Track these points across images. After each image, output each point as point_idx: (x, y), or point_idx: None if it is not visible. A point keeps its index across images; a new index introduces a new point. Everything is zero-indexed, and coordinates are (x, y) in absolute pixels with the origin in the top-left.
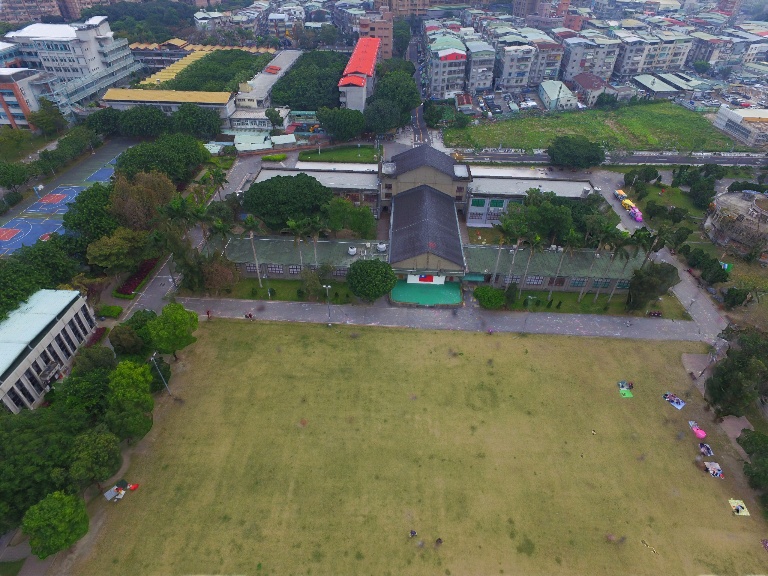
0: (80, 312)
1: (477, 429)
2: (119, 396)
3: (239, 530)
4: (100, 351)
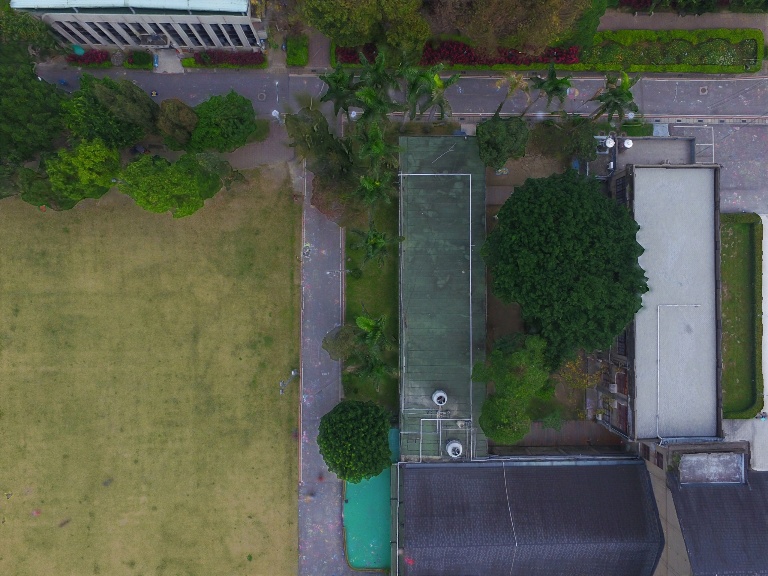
0: (239, 25)
1: (130, 569)
2: (47, 170)
3: (6, 328)
4: (117, 109)
